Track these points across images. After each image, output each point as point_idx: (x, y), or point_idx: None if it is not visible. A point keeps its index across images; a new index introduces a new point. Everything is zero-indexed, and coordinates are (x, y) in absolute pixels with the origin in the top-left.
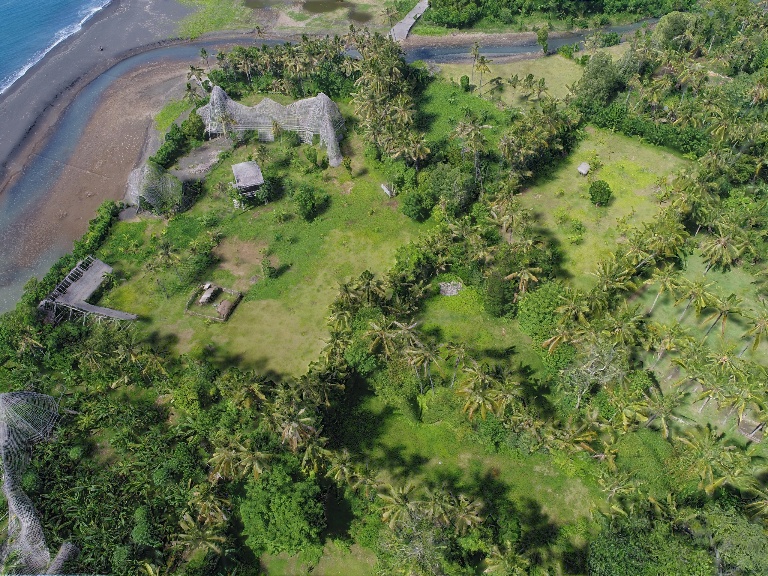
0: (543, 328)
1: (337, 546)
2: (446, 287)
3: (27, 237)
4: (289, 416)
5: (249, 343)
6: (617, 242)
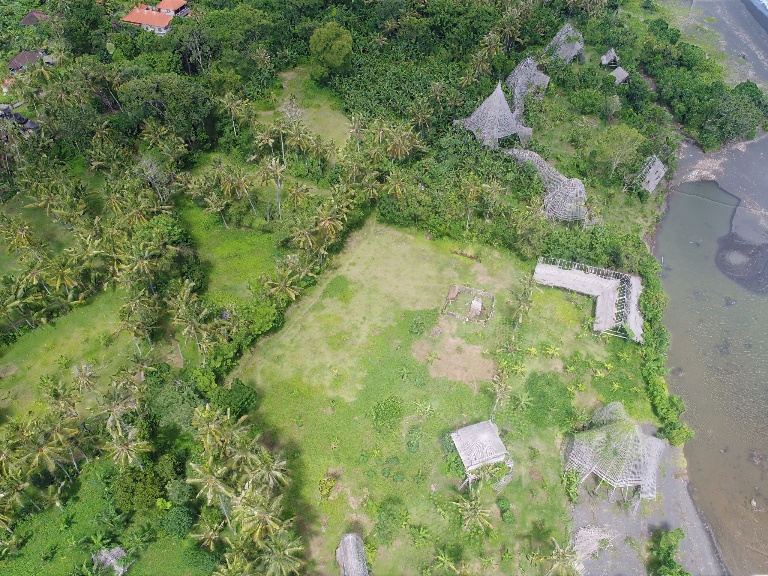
0: None
1: None
2: None
3: (767, 415)
4: None
5: (422, 270)
6: (14, 370)
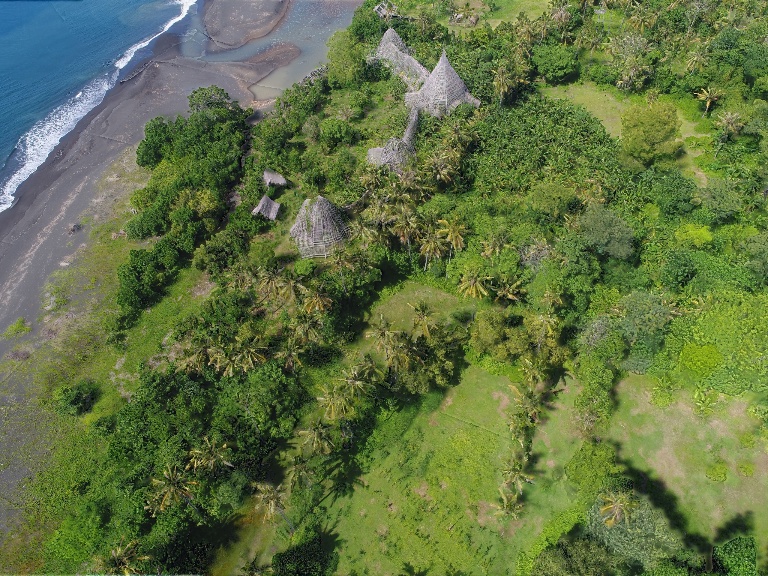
0: (666, 1)
1: (575, 85)
2: (597, 11)
3: (326, 6)
4: (564, 0)
5: None
6: None
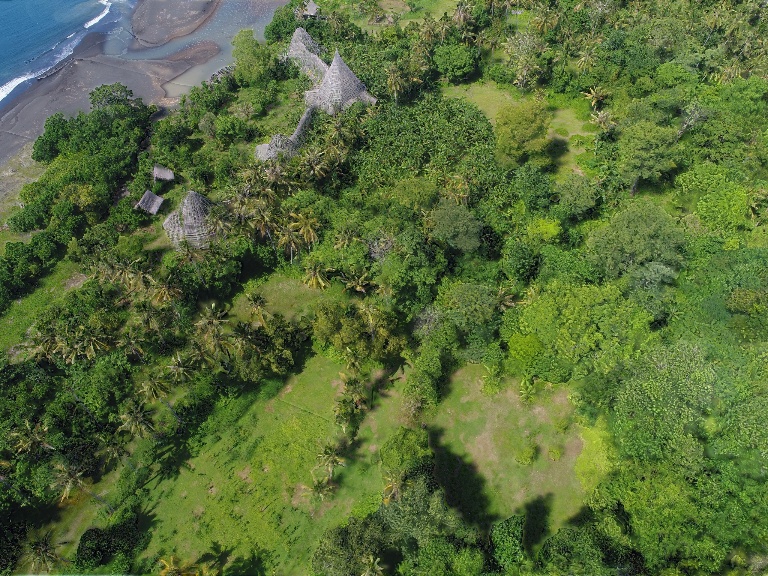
0: (574, 3)
1: (477, 84)
2: (515, 12)
3: (254, 6)
4: (461, 1)
5: None
6: None
